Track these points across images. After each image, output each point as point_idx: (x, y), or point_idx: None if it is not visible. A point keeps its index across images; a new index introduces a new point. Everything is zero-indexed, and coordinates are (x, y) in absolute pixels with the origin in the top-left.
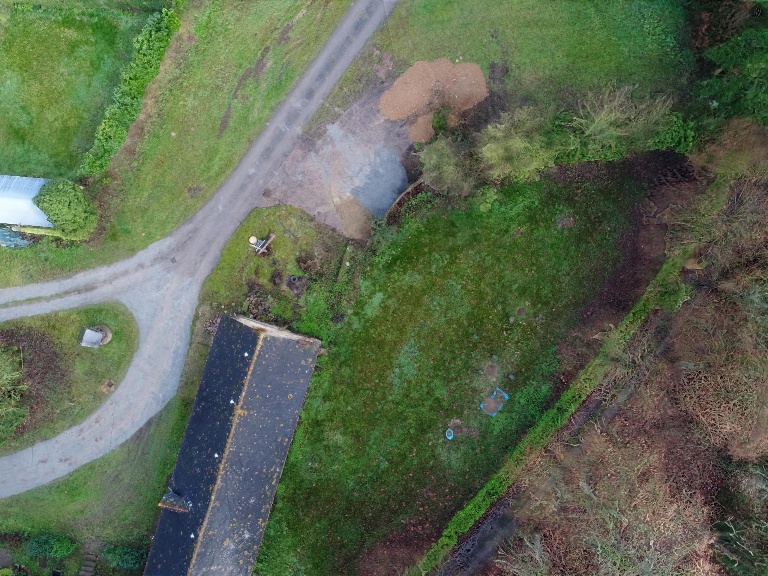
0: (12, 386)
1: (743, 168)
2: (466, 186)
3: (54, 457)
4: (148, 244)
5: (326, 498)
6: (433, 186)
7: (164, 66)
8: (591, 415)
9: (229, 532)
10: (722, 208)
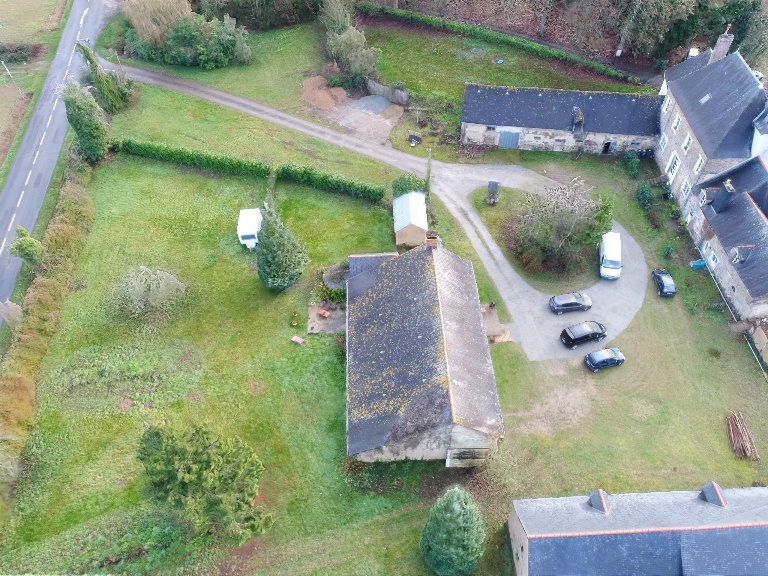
0: None
1: None
2: (371, 54)
3: None
4: None
5: None
6: None
7: None
8: None
9: None
10: (369, 2)
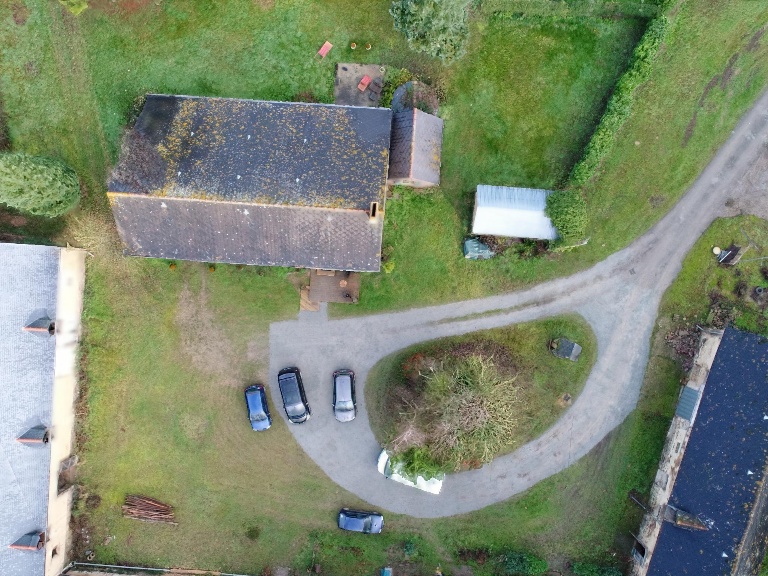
0: (505, 401)
1: None
2: None
3: (513, 472)
4: (607, 255)
5: None
6: None
7: None
8: None
9: (750, 551)
10: None
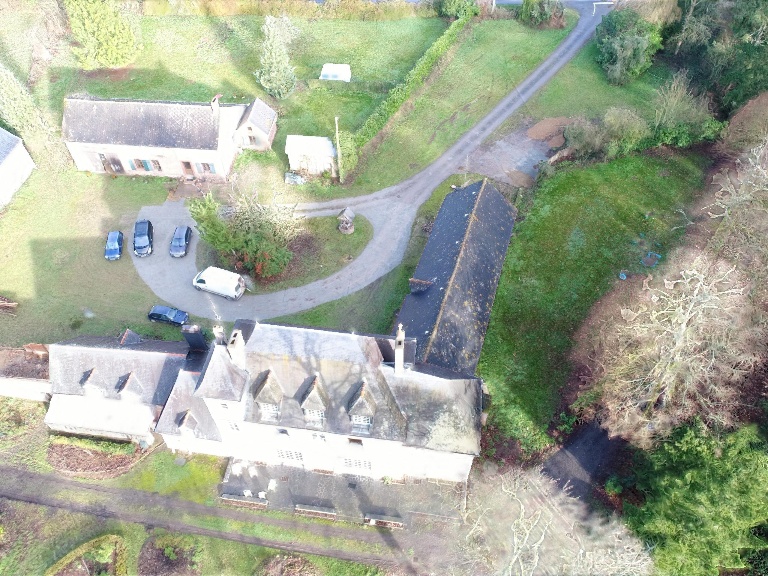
0: None
1: (766, 117)
2: (597, 140)
3: (302, 297)
4: (382, 188)
5: (531, 319)
6: (575, 144)
7: (398, 114)
8: (729, 265)
9: (467, 297)
10: None
